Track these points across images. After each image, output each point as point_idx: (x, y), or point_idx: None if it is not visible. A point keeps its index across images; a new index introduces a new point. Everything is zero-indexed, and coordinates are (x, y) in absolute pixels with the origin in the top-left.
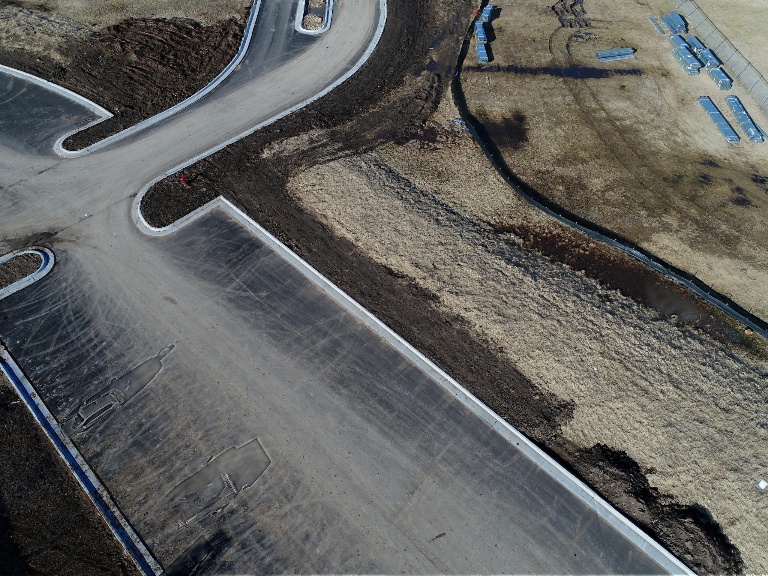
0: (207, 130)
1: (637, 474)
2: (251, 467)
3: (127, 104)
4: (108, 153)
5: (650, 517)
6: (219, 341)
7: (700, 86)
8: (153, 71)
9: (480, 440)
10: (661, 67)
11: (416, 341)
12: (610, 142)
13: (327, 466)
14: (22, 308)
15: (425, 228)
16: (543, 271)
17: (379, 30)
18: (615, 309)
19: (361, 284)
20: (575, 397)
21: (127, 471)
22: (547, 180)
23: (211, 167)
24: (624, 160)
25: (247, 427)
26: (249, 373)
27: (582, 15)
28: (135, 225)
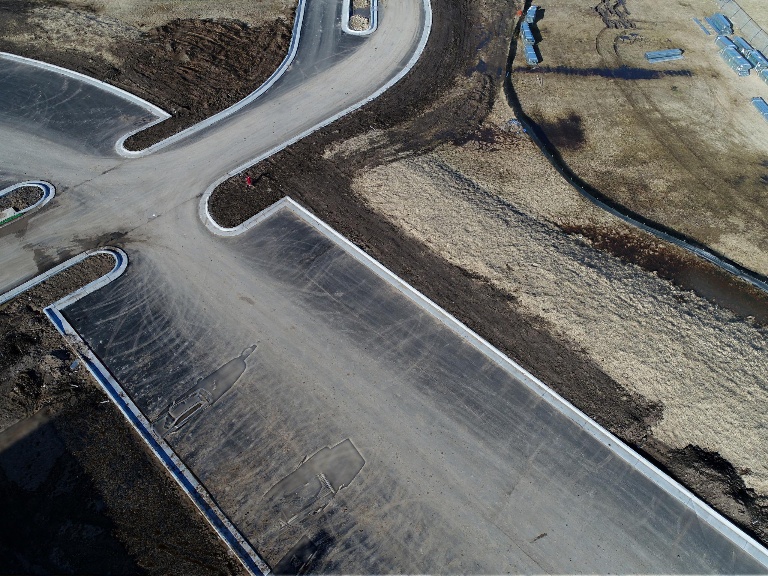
0: (265, 131)
1: (733, 475)
2: (346, 467)
3: (183, 104)
4: (169, 153)
5: (750, 518)
6: (300, 341)
7: (751, 87)
8: (206, 72)
9: (571, 441)
10: (710, 68)
11: (497, 342)
12: (668, 143)
13: (422, 466)
14: (101, 308)
15: (495, 229)
16: (616, 272)
17: (426, 31)
18: (692, 310)
19: (436, 285)
20: (663, 398)
21: (223, 471)
22: (609, 181)
23: (274, 167)
24: (684, 161)
25: (338, 427)
26: (334, 373)
27: (626, 16)
28: (204, 225)
